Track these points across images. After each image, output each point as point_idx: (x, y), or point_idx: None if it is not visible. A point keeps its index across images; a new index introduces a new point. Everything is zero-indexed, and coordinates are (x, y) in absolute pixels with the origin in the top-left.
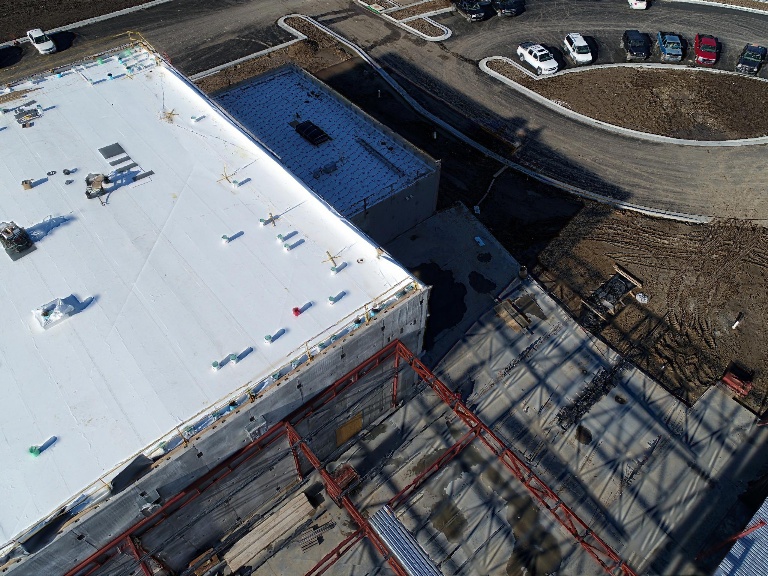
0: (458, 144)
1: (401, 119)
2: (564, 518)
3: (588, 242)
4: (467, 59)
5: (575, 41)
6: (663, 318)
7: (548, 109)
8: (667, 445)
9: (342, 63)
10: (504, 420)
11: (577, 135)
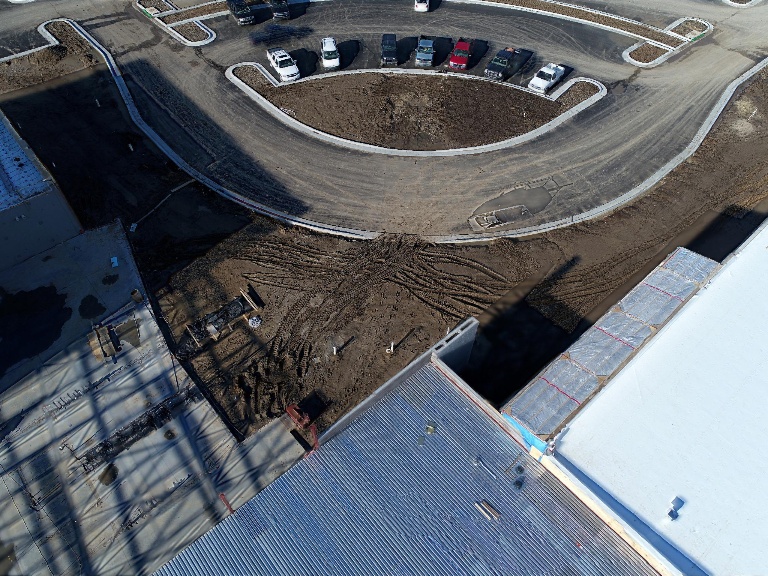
0: (157, 156)
1: (109, 130)
2: (37, 568)
3: (231, 261)
4: (217, 65)
5: (324, 46)
6: (266, 344)
7: (272, 118)
8: (192, 485)
9: (82, 70)
10: (32, 459)
11: (287, 146)
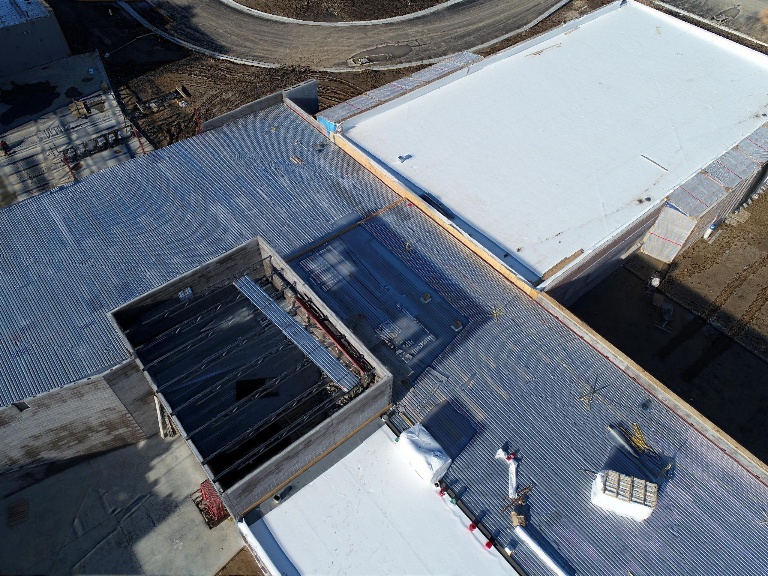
0: (129, 20)
1: (96, 3)
2: None
3: (172, 74)
4: None
5: None
6: (189, 114)
7: (218, 1)
8: None
9: None
10: (29, 159)
11: (226, 17)
